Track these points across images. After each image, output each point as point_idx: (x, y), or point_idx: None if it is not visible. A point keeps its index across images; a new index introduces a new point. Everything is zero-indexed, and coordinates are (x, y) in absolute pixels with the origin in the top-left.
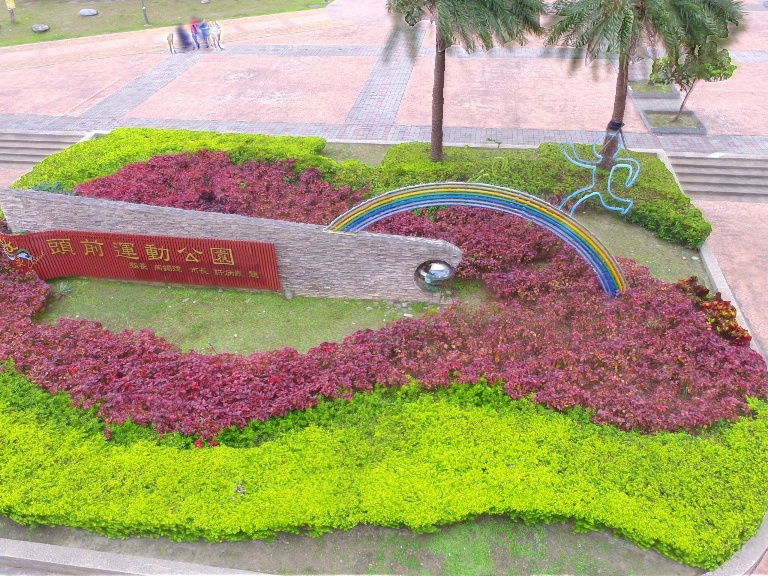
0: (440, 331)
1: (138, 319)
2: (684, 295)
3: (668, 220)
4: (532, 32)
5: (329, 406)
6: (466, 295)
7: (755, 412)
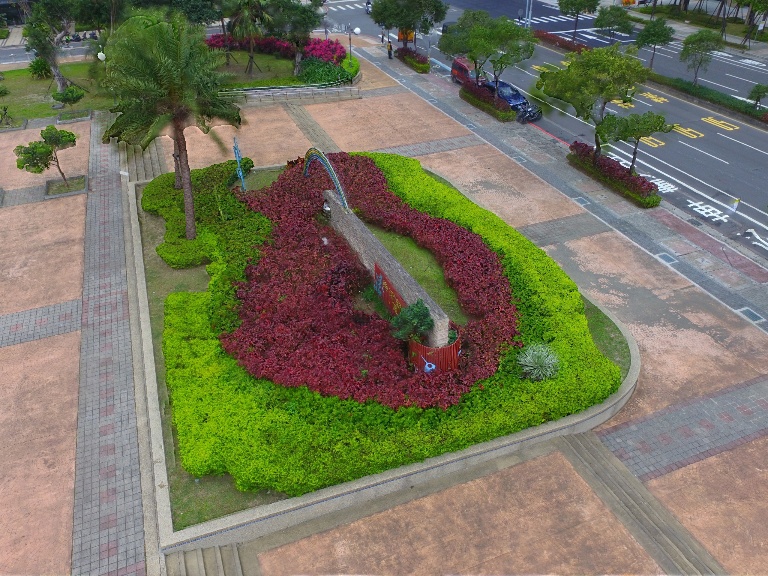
0: None
1: None
2: None
3: (242, 166)
4: None
5: None
6: None
7: None
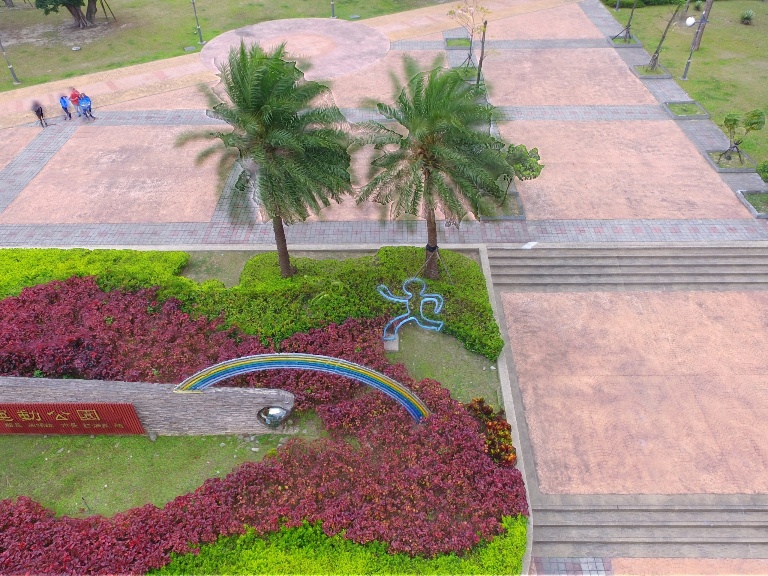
0: (275, 474)
1: (17, 476)
2: (472, 418)
3: (471, 337)
4: (346, 193)
5: (180, 561)
6: (305, 423)
7: (506, 531)
